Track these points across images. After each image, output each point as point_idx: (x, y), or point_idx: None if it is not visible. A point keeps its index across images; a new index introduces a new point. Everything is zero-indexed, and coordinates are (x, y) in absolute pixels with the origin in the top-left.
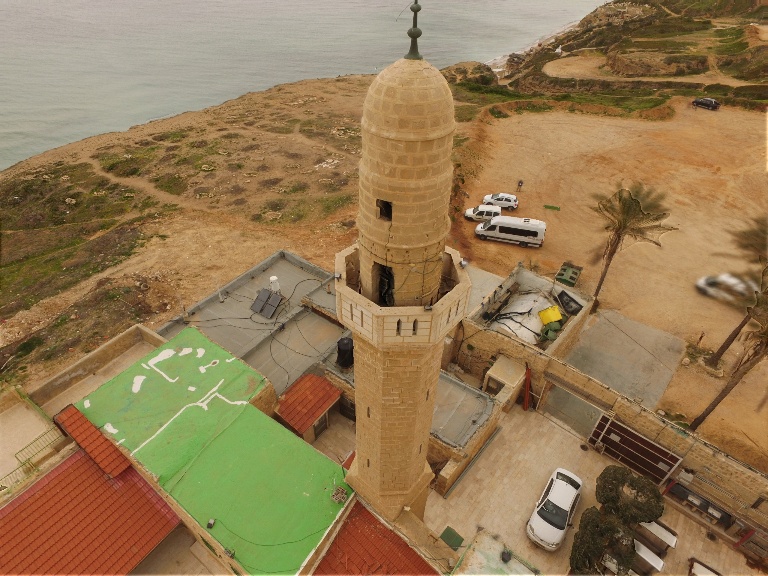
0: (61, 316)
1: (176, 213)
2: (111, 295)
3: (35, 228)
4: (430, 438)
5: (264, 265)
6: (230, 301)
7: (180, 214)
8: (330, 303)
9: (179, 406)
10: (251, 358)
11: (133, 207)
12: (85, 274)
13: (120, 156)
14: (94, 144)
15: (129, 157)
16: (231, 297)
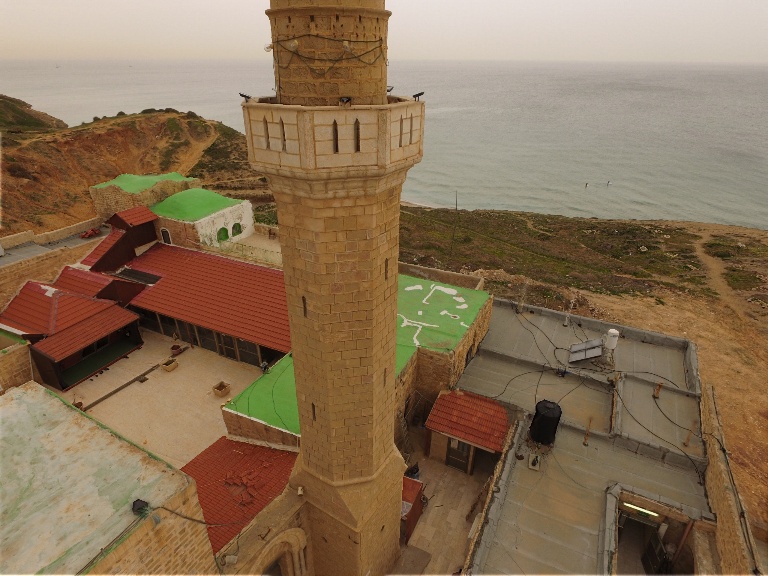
0: (506, 281)
1: (706, 298)
2: (547, 293)
3: (598, 252)
4: (462, 571)
5: (649, 336)
6: (571, 330)
7: (708, 301)
8: (636, 401)
9: (399, 311)
10: (503, 363)
11: (679, 275)
12: (568, 283)
13: (735, 243)
14: (733, 230)
15: (741, 246)
16: (573, 326)
